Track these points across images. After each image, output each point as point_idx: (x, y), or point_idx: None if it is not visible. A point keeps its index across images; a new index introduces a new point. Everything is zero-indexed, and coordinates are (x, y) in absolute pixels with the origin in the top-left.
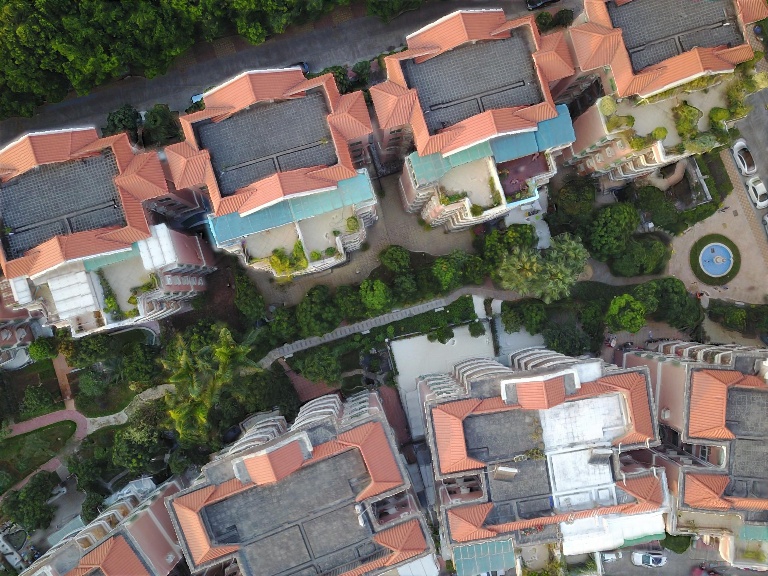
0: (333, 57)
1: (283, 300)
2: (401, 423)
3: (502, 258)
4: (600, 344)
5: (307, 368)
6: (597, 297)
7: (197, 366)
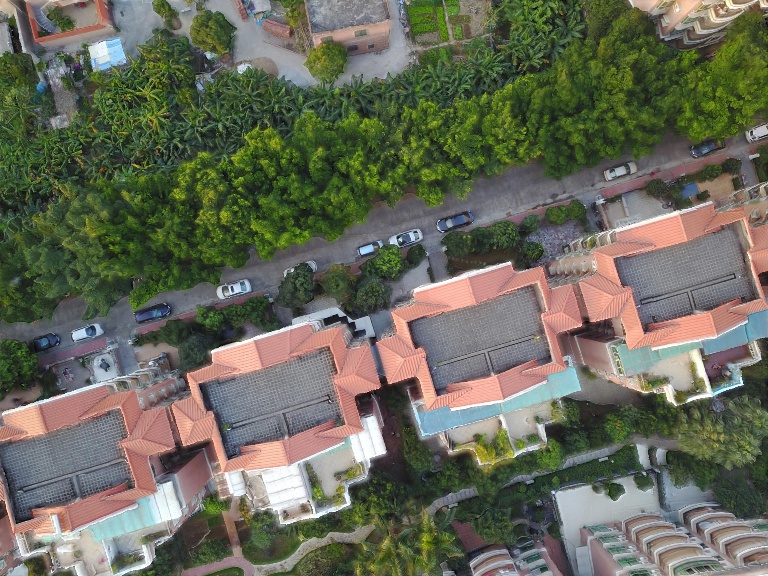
0: (496, 205)
1: (446, 448)
2: (565, 574)
3: (676, 417)
4: (767, 496)
5: (483, 529)
6: (765, 448)
7: (399, 551)
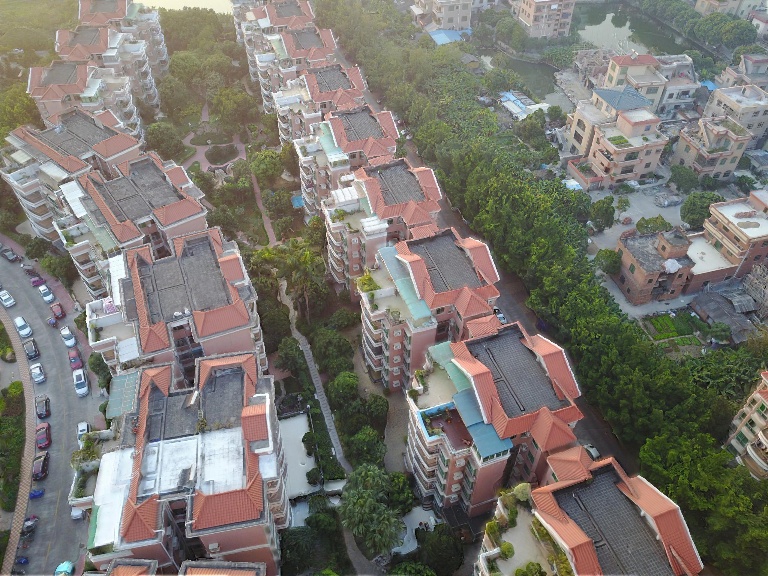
0: None
1: None
2: None
3: None
4: None
5: None
6: None
7: (299, 250)
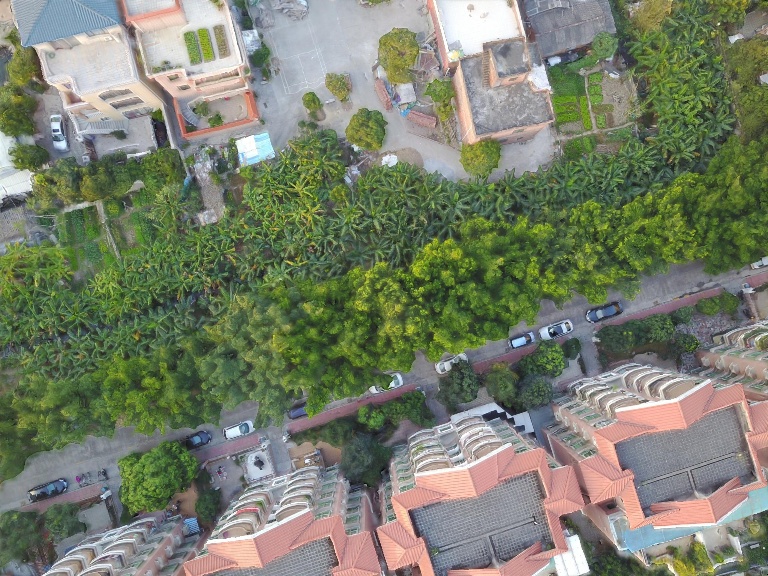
0: (643, 294)
1: (599, 538)
2: None
3: None
4: None
5: None
6: None
7: None
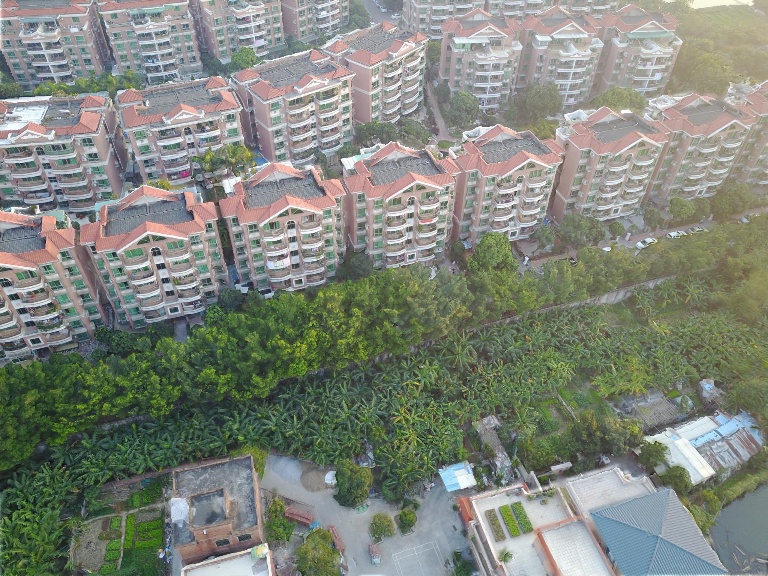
0: None
1: None
2: None
3: None
4: None
5: None
6: None
7: None
